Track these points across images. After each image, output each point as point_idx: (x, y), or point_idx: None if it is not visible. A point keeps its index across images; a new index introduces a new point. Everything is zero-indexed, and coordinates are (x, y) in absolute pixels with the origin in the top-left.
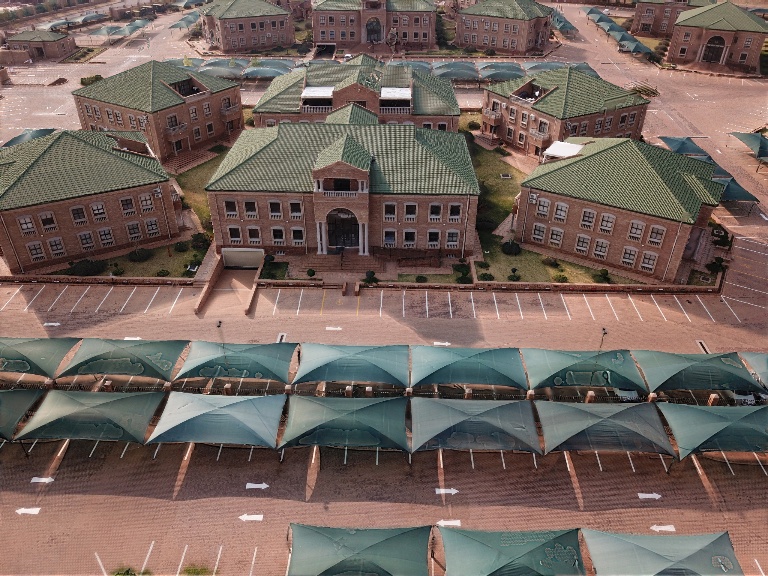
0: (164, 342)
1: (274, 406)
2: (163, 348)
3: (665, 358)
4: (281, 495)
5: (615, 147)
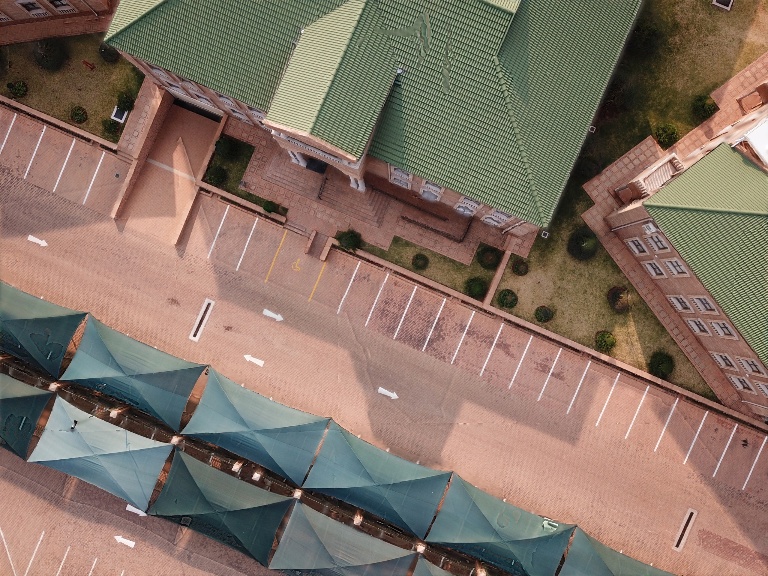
0: (52, 319)
1: (155, 460)
2: (51, 327)
3: (598, 568)
4: (154, 529)
5: None
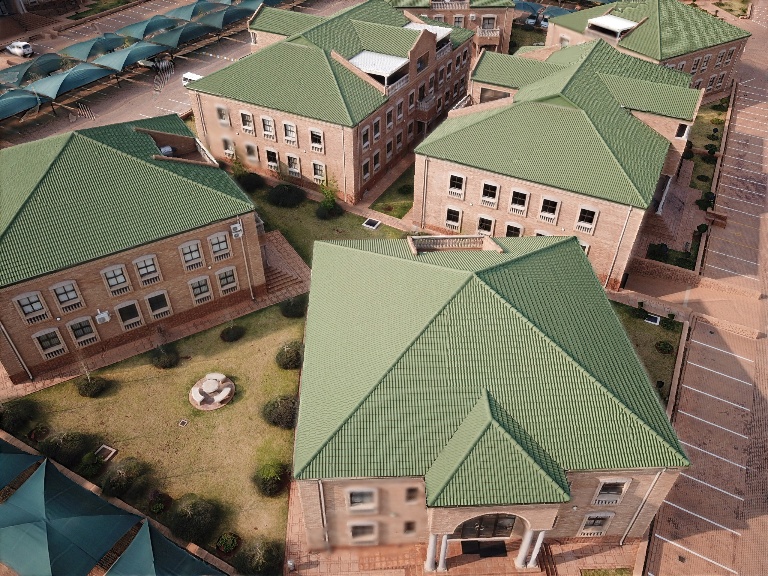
0: None
1: None
2: None
3: None
4: None
5: (660, 2)
